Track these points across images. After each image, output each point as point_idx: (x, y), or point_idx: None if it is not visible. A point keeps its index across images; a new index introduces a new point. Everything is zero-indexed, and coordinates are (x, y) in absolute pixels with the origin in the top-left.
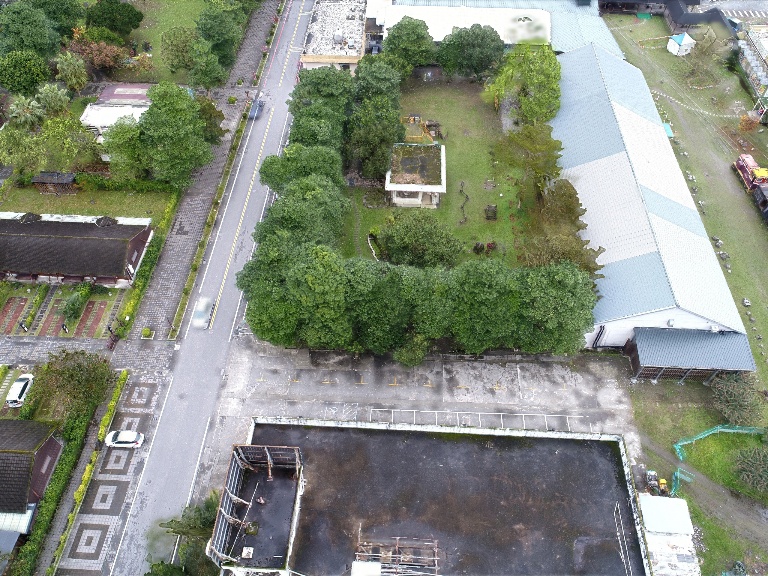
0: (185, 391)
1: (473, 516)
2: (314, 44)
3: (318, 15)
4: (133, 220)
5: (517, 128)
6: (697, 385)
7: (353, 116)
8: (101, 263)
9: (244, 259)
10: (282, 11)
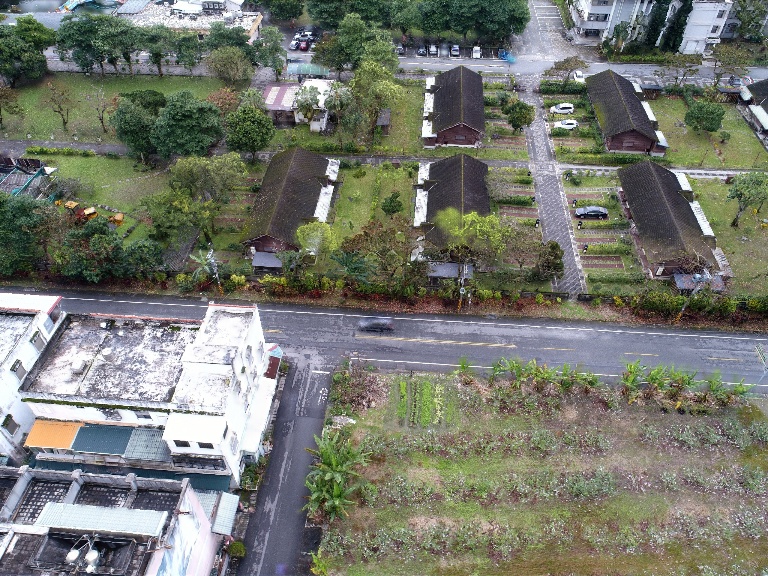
0: (545, 69)
1: None
2: None
3: None
4: (429, 83)
5: None
6: None
7: None
8: (476, 80)
9: (450, 61)
10: (134, 62)
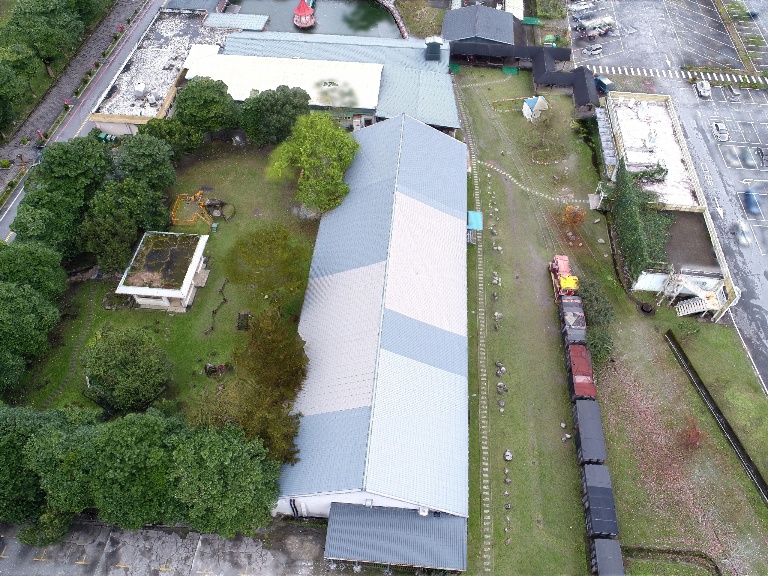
0: None
1: None
2: (114, 99)
3: (133, 63)
4: None
5: (317, 209)
6: (408, 575)
7: (90, 202)
8: None
9: None
10: (109, 54)
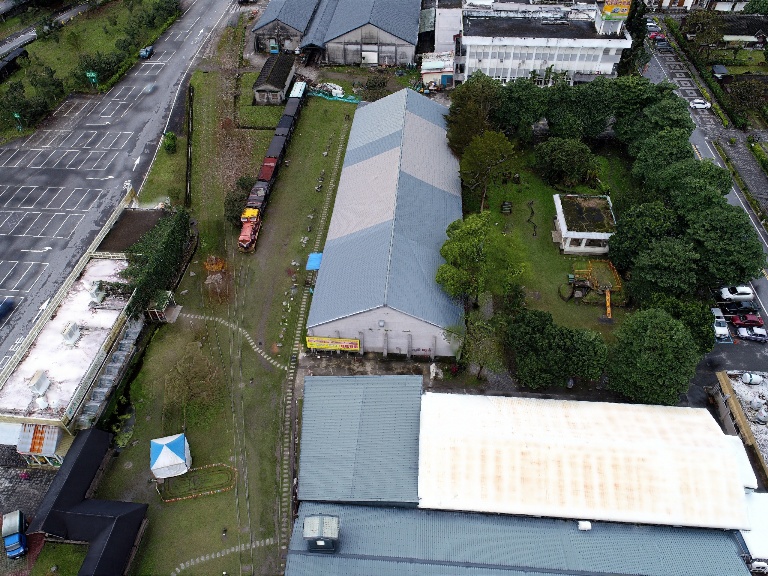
0: None
1: (527, 29)
2: None
3: None
4: None
5: None
6: None
7: None
8: None
9: None
10: None
